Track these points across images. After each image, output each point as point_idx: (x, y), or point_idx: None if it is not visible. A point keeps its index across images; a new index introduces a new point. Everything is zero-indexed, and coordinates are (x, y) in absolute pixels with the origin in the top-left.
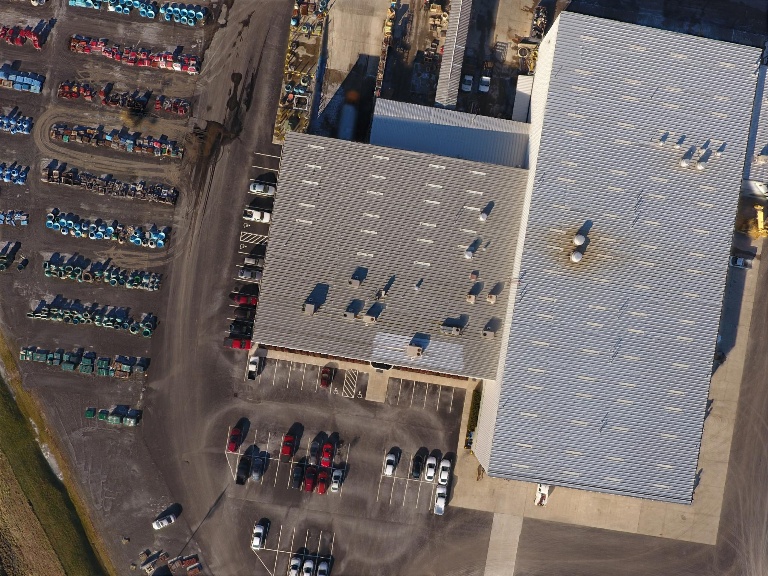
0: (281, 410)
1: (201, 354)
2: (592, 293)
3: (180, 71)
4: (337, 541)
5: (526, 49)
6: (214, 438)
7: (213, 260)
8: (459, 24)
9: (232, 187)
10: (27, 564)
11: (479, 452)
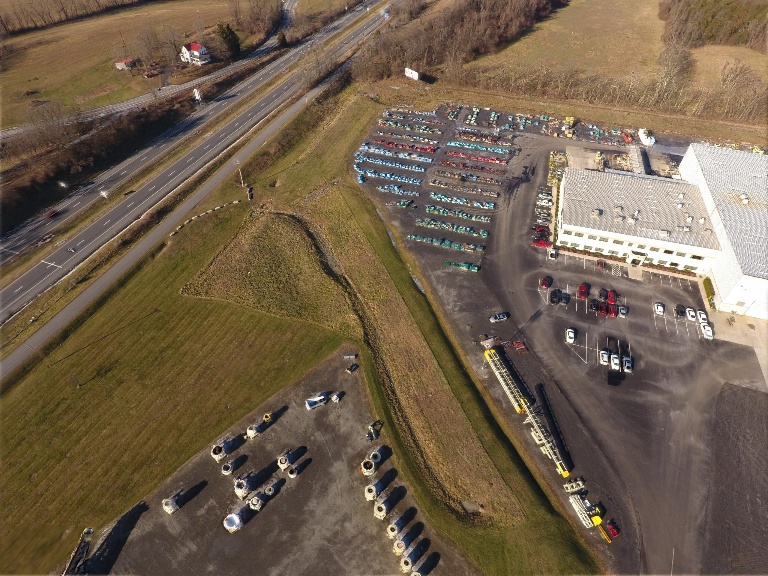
0: (573, 276)
1: (517, 248)
2: (763, 215)
3: (498, 163)
4: (633, 348)
5: (670, 172)
6: (530, 283)
7: (521, 216)
8: (637, 155)
9: (528, 195)
10: (387, 340)
11: (727, 290)
